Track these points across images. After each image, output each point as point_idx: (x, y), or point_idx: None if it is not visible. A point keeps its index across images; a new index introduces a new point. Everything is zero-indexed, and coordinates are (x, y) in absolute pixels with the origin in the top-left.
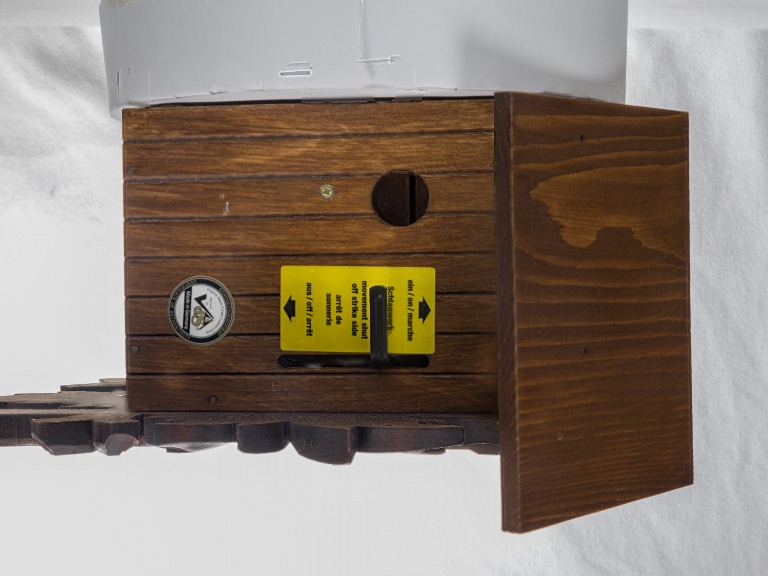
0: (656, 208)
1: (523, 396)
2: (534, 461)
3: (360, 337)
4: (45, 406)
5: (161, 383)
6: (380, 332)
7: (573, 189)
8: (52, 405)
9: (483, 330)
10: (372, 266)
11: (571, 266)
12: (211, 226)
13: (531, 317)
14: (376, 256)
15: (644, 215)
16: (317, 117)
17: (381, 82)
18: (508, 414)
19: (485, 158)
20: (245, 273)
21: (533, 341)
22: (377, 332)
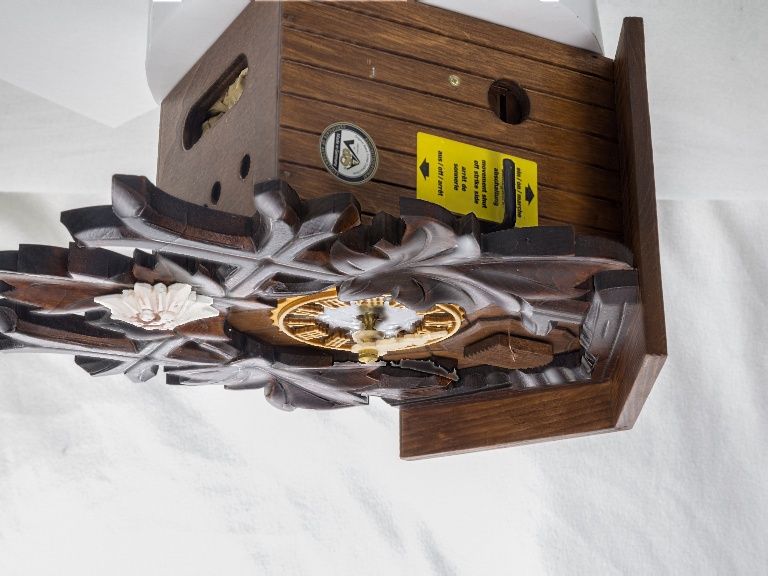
0: None
1: None
2: None
3: (481, 206)
4: (107, 252)
5: None
6: (512, 197)
7: None
8: (113, 253)
9: (573, 220)
10: (489, 150)
11: None
12: (359, 83)
13: None
14: (492, 143)
15: None
16: (446, 21)
17: None
18: (651, 258)
19: (569, 88)
20: (387, 130)
21: None
22: (510, 196)
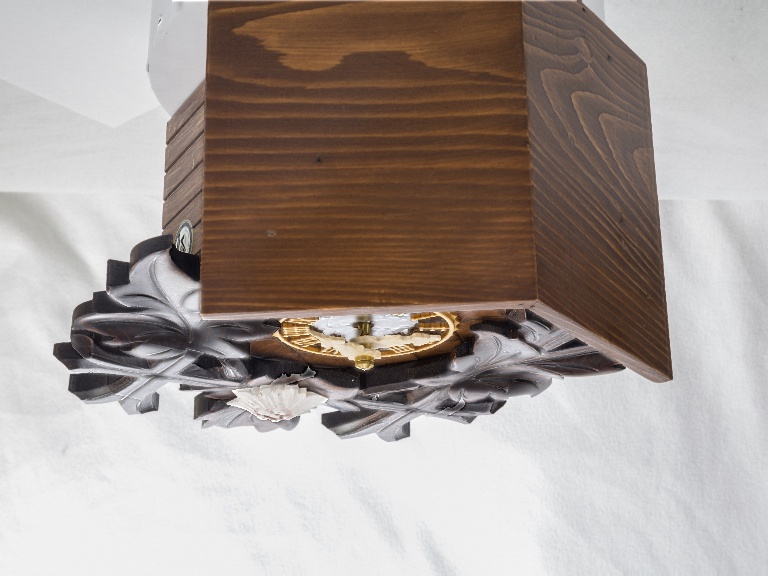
0: (453, 32)
1: (212, 195)
2: (227, 252)
3: None
4: None
5: None
6: None
7: (303, 24)
8: None
9: None
10: None
11: (297, 87)
12: (188, 181)
13: (229, 130)
14: None
15: (430, 39)
16: None
17: (187, 2)
18: None
19: None
20: (197, 206)
21: (231, 150)
22: None
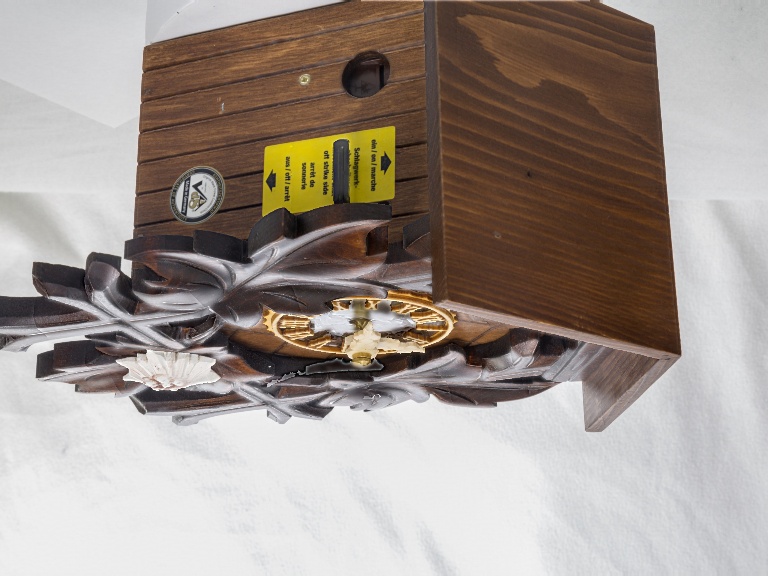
0: (616, 89)
1: (450, 181)
2: (464, 243)
3: (330, 195)
4: (84, 343)
5: None
6: (342, 177)
7: (510, 35)
8: (90, 342)
9: None
10: (341, 134)
11: (509, 96)
12: (209, 125)
13: (459, 118)
14: (345, 125)
15: (600, 89)
16: (298, 23)
17: None
18: (435, 196)
19: None
20: (235, 158)
21: (462, 139)
22: (339, 177)
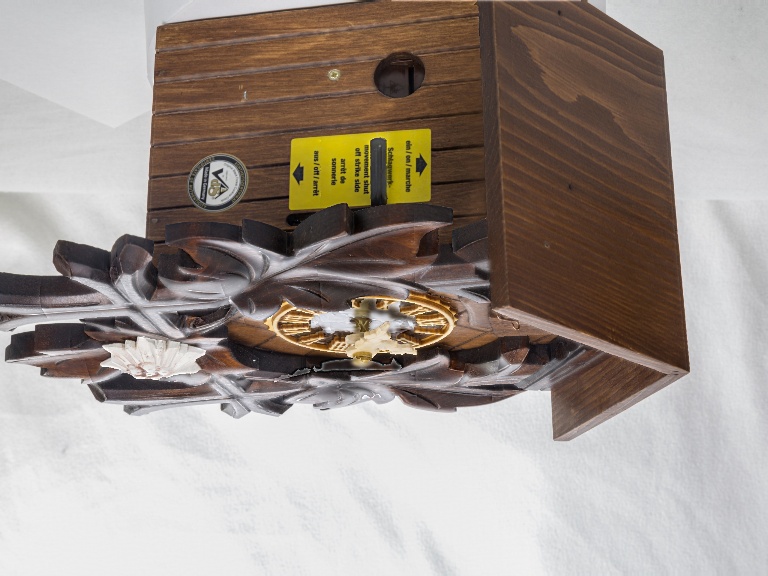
0: (635, 110)
1: (508, 188)
2: (521, 250)
3: (362, 193)
4: (69, 326)
5: (177, 248)
6: (380, 176)
7: (552, 48)
8: (75, 325)
9: (475, 177)
10: (374, 132)
11: (553, 109)
12: (230, 112)
13: (515, 127)
14: (377, 124)
15: (623, 109)
16: (327, 17)
17: None
18: (495, 202)
19: (474, 36)
20: (259, 148)
21: (517, 148)
22: (377, 176)
